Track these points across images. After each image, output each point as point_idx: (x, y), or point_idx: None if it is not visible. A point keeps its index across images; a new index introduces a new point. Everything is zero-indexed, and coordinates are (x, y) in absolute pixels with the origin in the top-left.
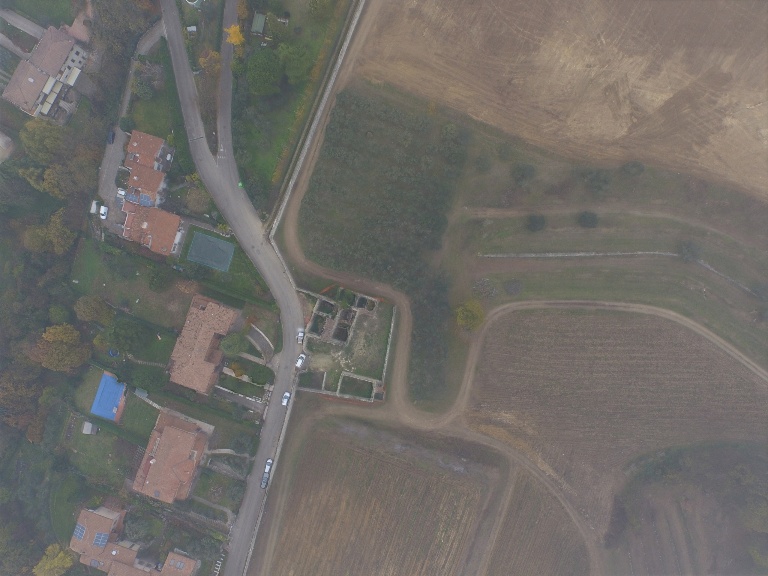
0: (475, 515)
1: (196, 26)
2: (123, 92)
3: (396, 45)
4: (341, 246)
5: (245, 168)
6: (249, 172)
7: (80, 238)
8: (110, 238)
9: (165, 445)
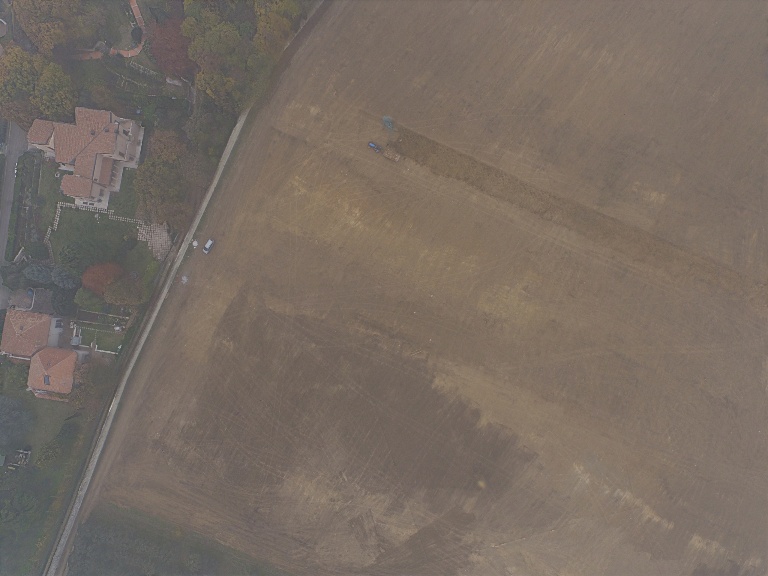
0: None
1: None
2: None
3: (141, 473)
4: None
5: None
6: None
7: None
8: None
9: None
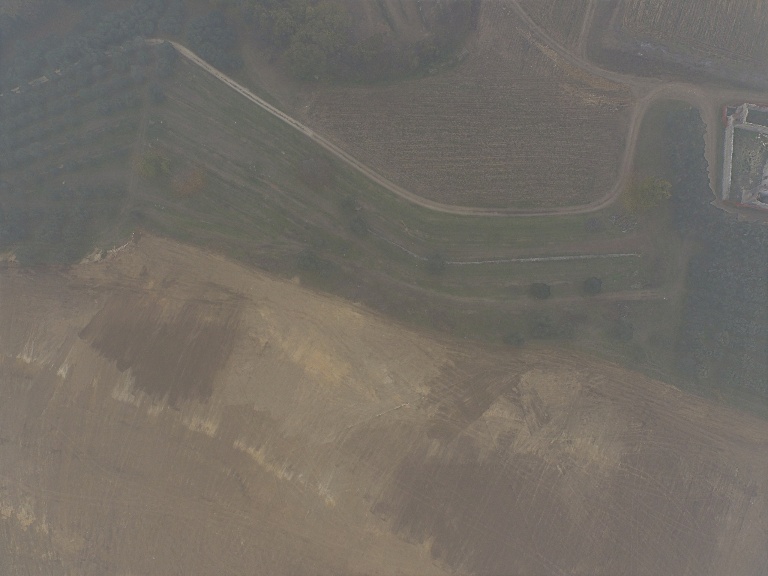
0: (627, 2)
1: None
2: None
3: (764, 458)
4: None
5: None
6: None
7: None
8: None
9: None
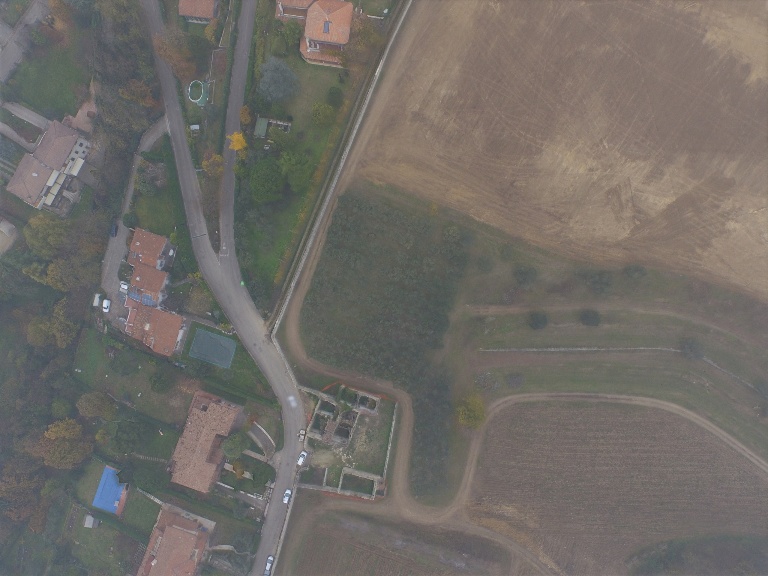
0: None
1: (199, 124)
2: (126, 186)
3: (398, 147)
4: (343, 346)
5: (247, 268)
6: (251, 271)
7: (83, 328)
8: (113, 331)
9: (166, 546)
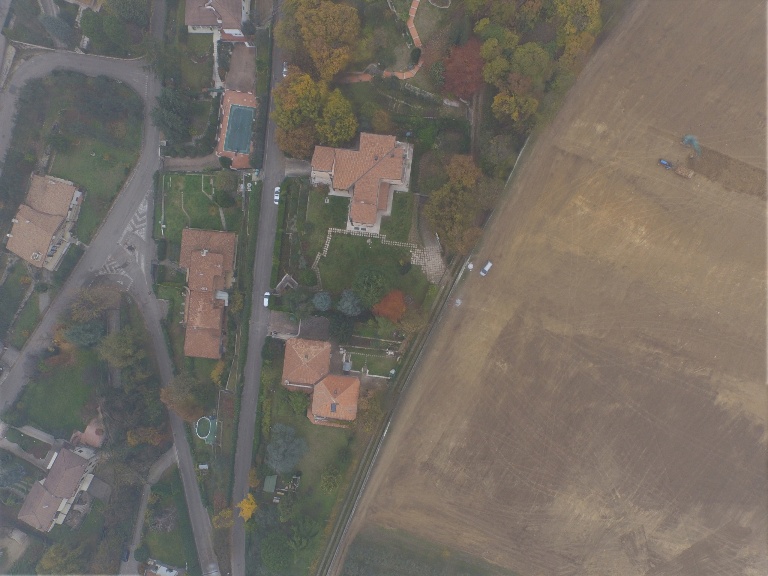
0: None
1: (208, 461)
2: (136, 513)
3: (408, 495)
4: None
5: None
6: None
7: None
8: None
9: None
